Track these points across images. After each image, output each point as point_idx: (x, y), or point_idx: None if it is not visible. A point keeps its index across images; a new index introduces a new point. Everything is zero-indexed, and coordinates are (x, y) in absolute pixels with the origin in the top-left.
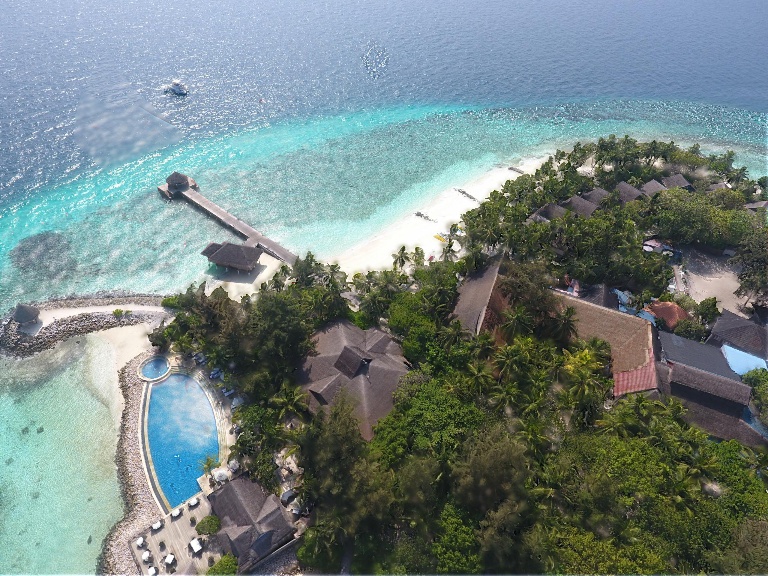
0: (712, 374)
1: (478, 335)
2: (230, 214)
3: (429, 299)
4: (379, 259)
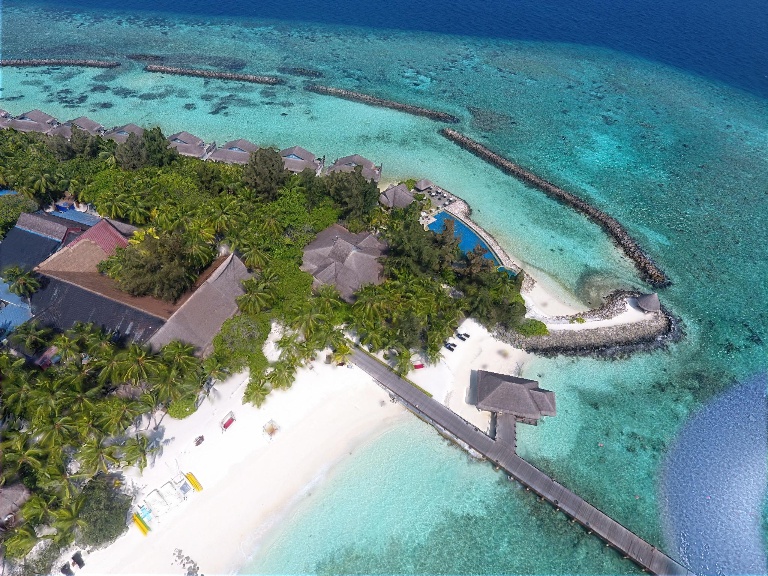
0: (41, 223)
1: (232, 252)
2: (580, 519)
3: (267, 289)
4: (309, 425)
